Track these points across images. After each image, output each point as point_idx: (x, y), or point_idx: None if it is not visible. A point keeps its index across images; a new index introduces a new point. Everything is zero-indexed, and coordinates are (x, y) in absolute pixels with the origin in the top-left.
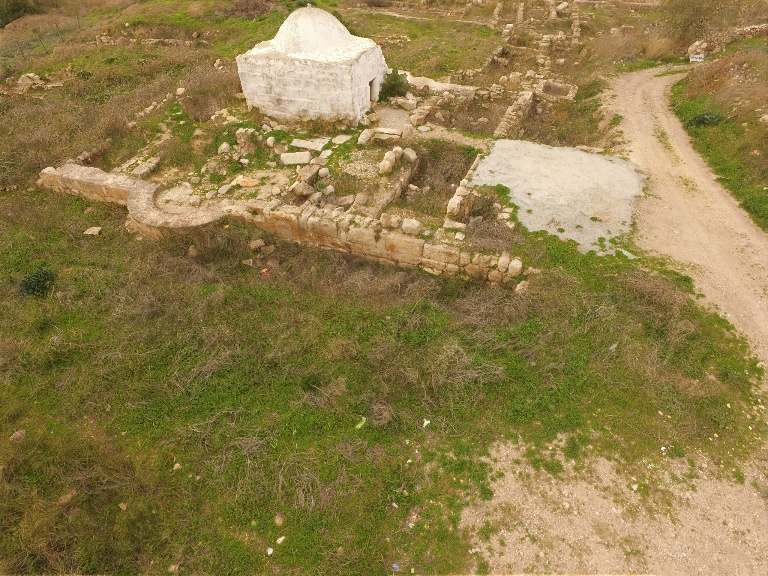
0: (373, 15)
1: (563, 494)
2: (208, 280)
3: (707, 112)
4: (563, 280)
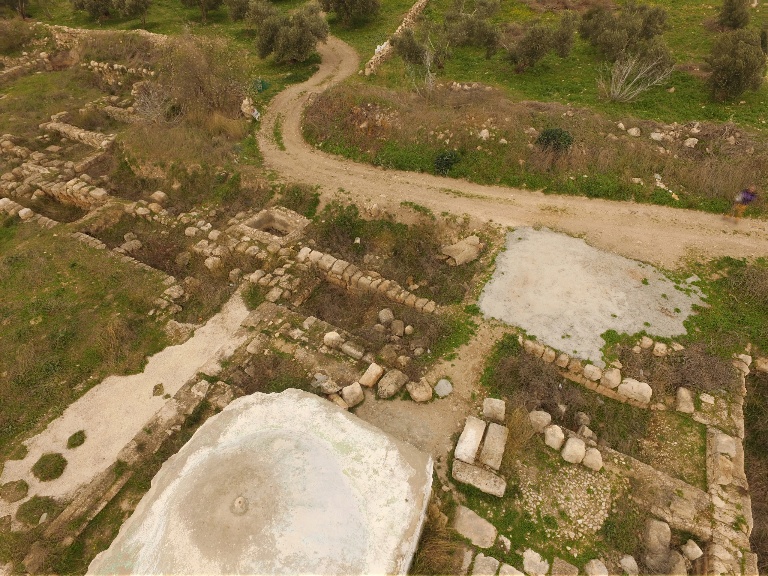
0: None
1: None
2: None
3: (426, 154)
4: None
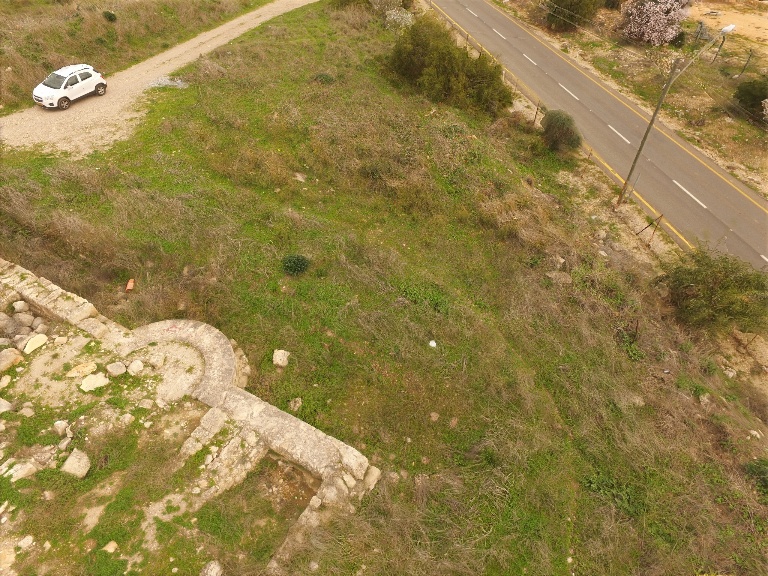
0: None
1: (70, 148)
2: None
3: None
4: None
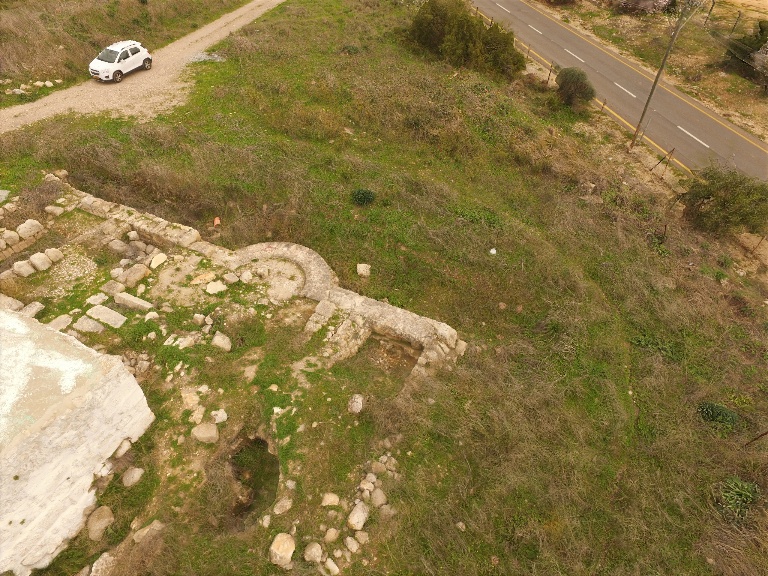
0: None
1: (135, 113)
2: None
3: None
4: None
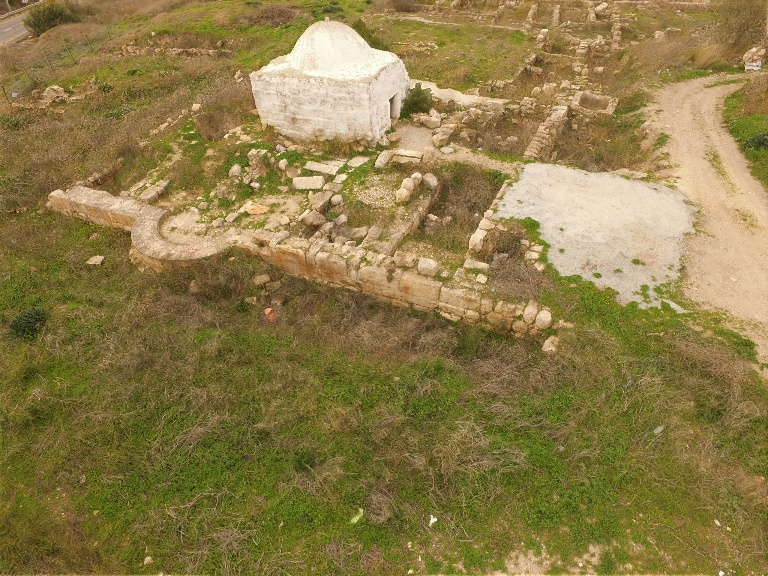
0: (400, 21)
1: None
2: (206, 322)
3: (767, 132)
4: (599, 342)
